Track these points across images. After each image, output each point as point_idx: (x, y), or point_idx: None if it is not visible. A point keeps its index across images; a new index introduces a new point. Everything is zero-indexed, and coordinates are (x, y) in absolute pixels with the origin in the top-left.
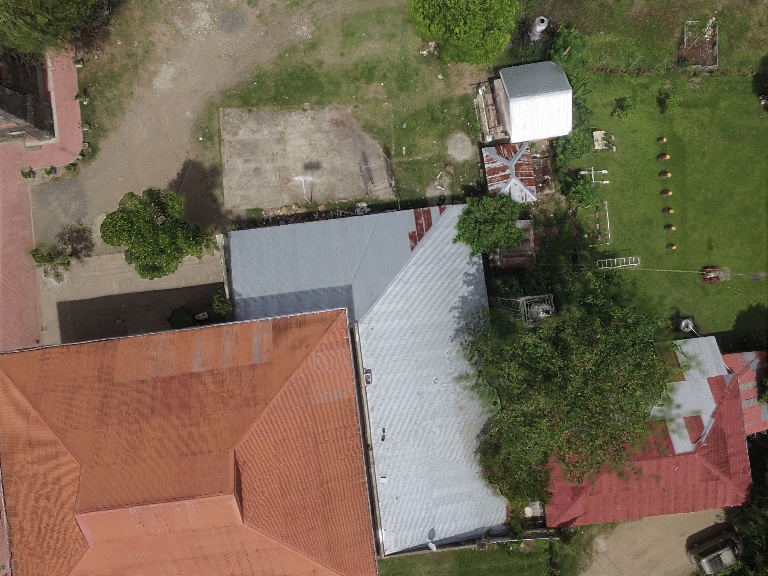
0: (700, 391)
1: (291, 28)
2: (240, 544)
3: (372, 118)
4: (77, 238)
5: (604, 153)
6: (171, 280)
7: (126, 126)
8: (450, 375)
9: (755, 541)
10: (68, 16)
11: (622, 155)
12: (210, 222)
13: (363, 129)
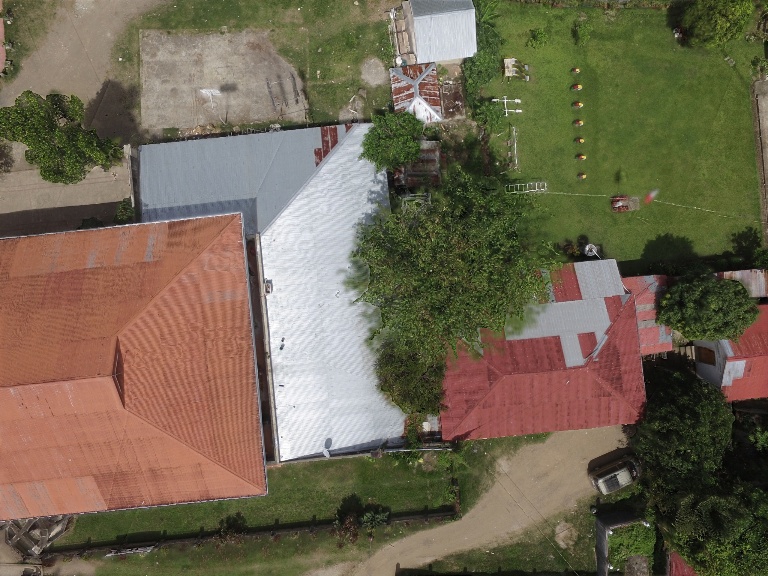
0: (596, 310)
1: None
2: (123, 431)
3: (288, 42)
4: None
5: (518, 83)
6: (88, 196)
7: (48, 46)
8: (351, 289)
9: (646, 457)
10: None
11: (536, 85)
12: (127, 141)
13: (279, 52)
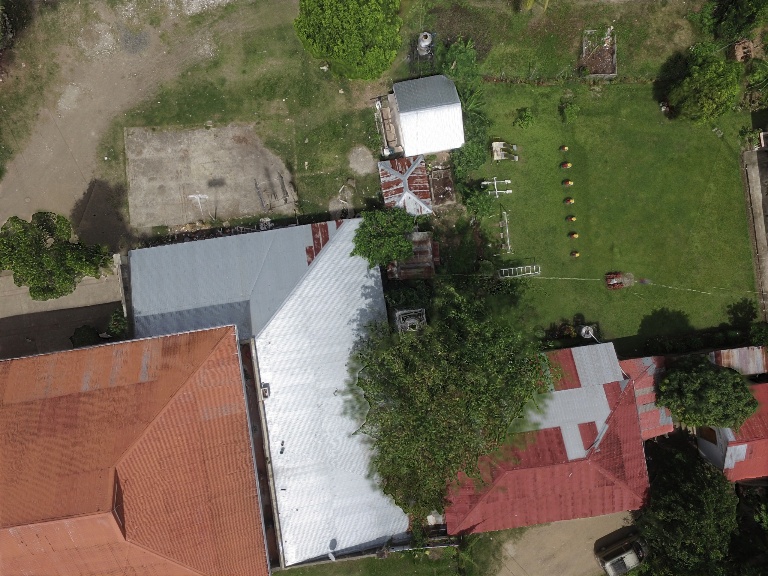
0: (595, 397)
1: (193, 47)
2: (126, 560)
3: (274, 134)
4: None
5: (507, 163)
6: (79, 298)
7: (32, 147)
8: (349, 387)
9: (651, 544)
10: None
11: (525, 164)
12: (116, 240)
13: (265, 145)
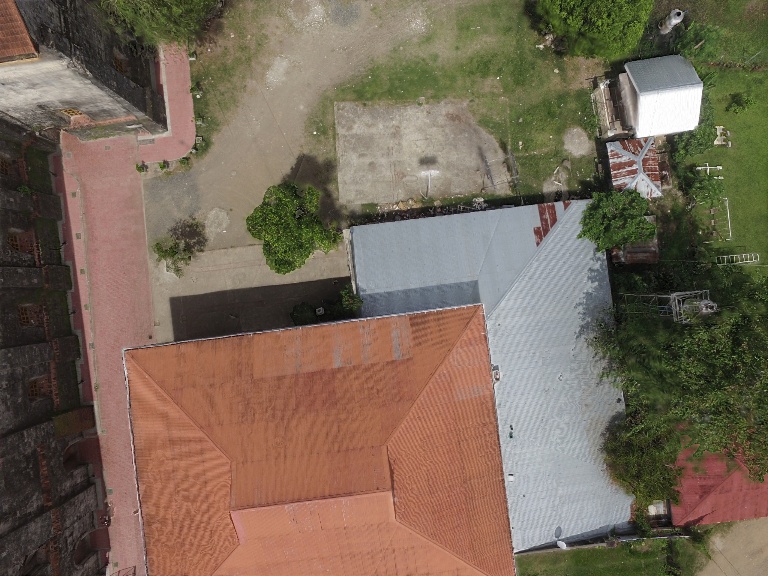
0: None
1: (405, 21)
2: (389, 541)
3: (488, 112)
4: (190, 233)
5: (719, 149)
6: (285, 275)
7: (239, 120)
8: (575, 372)
9: None
10: (195, 8)
11: (737, 151)
12: (324, 217)
13: (479, 123)
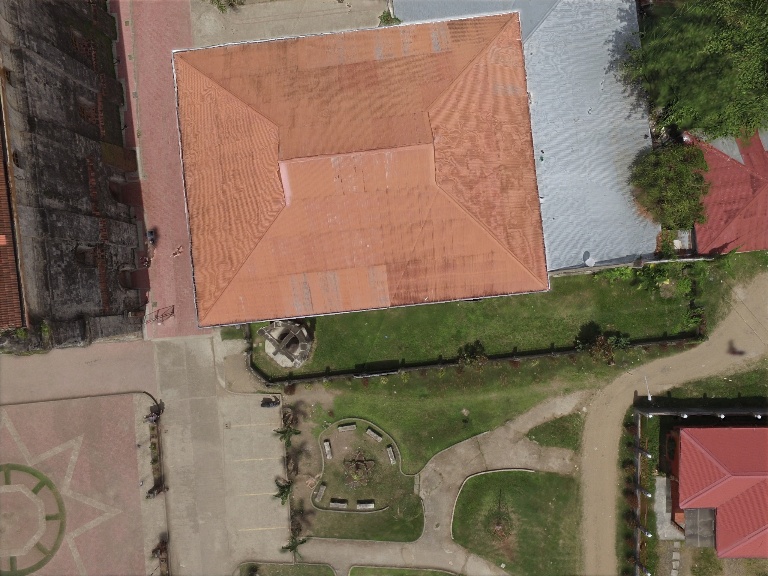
0: None
1: None
2: (428, 211)
3: None
4: None
5: None
6: (322, 28)
7: None
8: (604, 105)
9: None
10: None
11: None
12: None
13: None
